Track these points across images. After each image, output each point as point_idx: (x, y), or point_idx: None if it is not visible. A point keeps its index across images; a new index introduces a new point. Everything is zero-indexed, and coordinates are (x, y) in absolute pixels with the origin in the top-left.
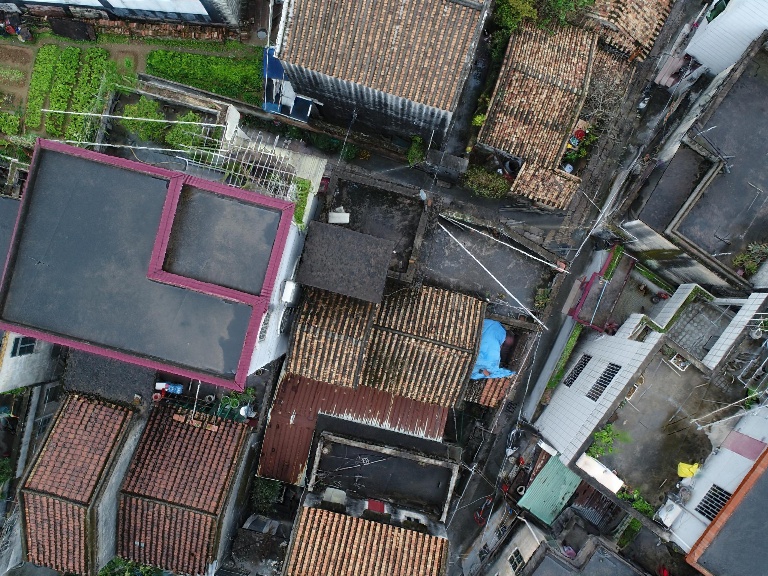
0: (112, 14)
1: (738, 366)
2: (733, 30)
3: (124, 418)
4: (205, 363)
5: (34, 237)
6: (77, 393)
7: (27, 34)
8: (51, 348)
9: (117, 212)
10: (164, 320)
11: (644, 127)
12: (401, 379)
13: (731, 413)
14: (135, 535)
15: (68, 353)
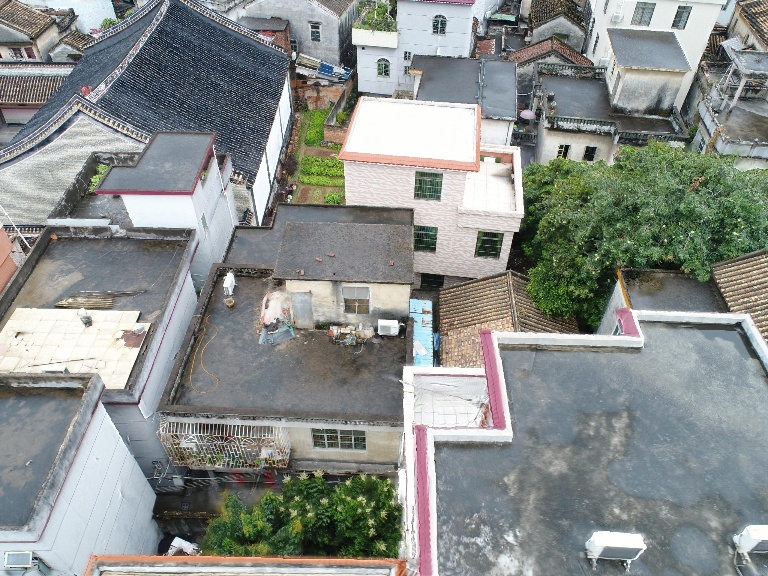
0: None
1: None
2: None
3: None
4: None
5: None
6: None
7: None
8: None
9: None
10: None
11: None
12: None
13: None
14: None
15: None
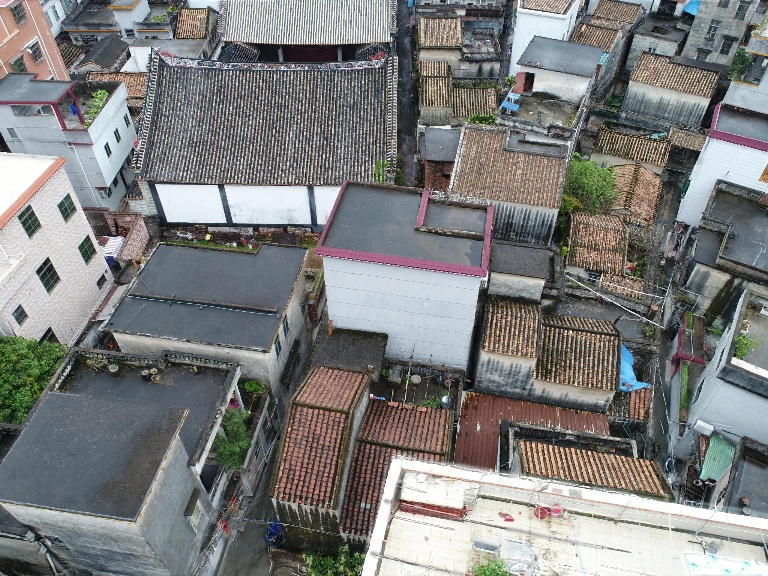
0: (313, 231)
1: None
2: (700, 190)
3: (363, 377)
4: (458, 264)
5: (343, 216)
6: (322, 367)
7: (256, 243)
8: (281, 372)
9: (392, 205)
10: (428, 247)
11: (669, 276)
12: (567, 369)
13: None
14: (362, 494)
15: (315, 344)
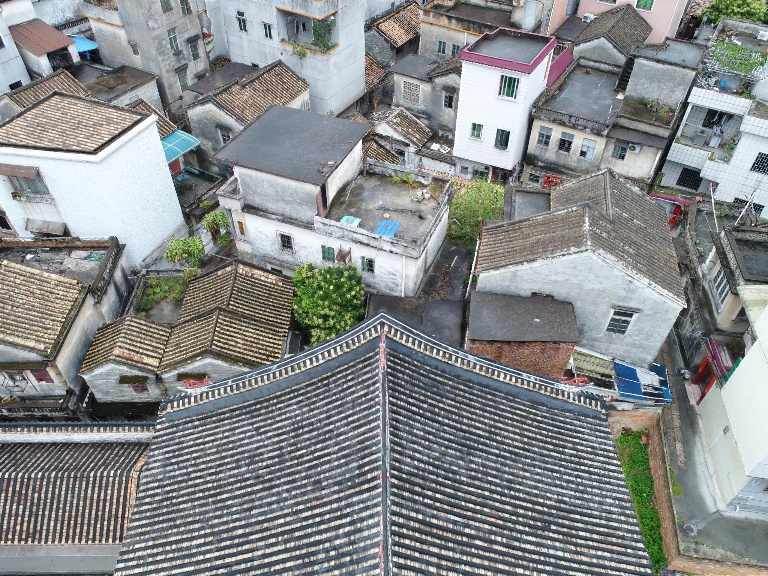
0: None
1: (715, 122)
2: None
3: None
4: None
5: None
6: None
7: None
8: None
9: None
10: None
11: None
12: None
13: (762, 103)
14: None
15: None
